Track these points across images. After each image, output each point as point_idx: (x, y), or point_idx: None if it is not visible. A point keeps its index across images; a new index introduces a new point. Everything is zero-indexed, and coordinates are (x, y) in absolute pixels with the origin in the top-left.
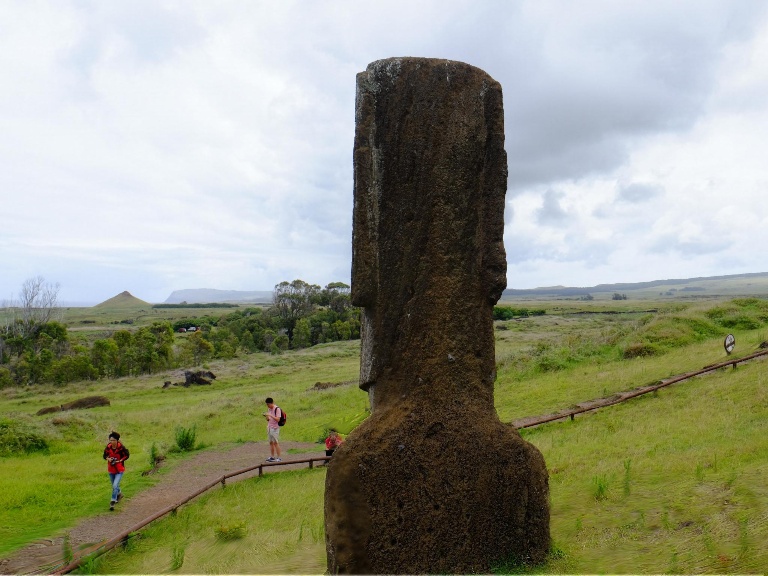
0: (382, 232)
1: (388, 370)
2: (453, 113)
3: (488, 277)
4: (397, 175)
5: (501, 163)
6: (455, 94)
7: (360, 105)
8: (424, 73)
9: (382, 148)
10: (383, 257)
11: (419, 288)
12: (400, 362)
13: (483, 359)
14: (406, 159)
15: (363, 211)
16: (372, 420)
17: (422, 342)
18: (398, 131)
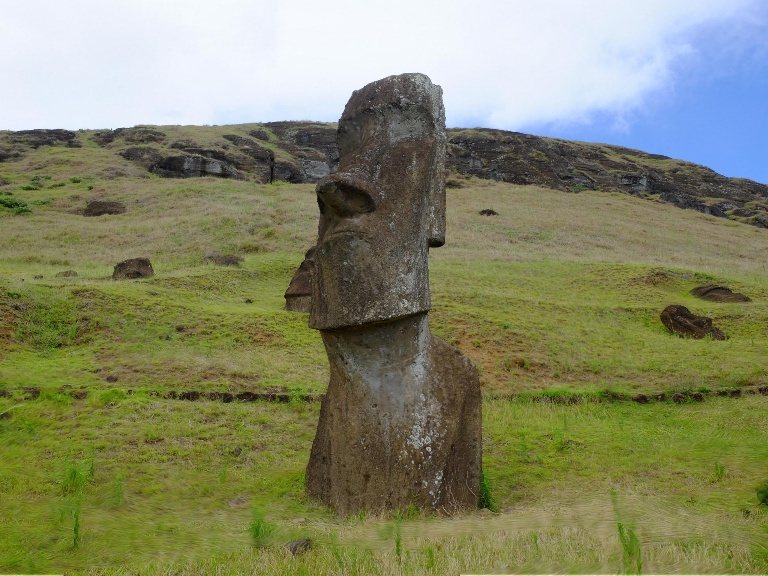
0: None
1: None
2: None
3: None
4: None
5: None
6: None
7: None
8: None
9: None
10: None
11: None
12: None
13: None
14: None
15: None
16: None
17: None
18: None
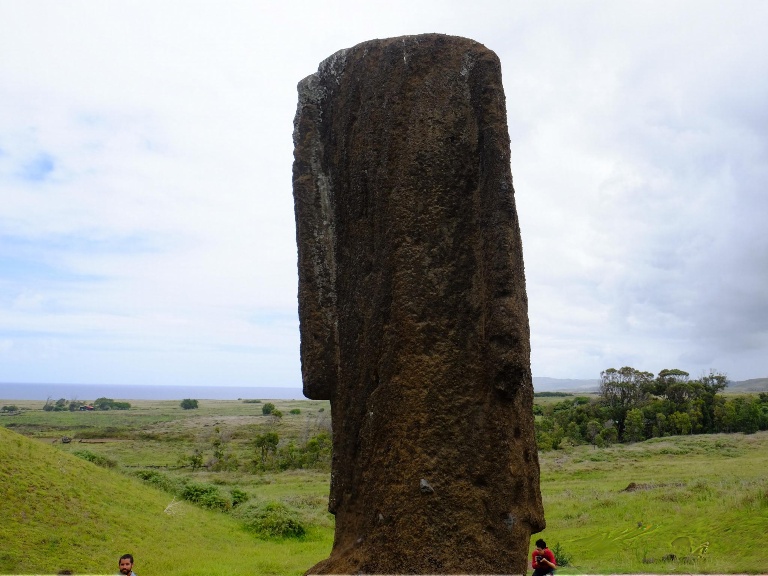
0: (340, 292)
1: (348, 496)
2: (415, 107)
3: (491, 354)
4: (349, 209)
5: (498, 171)
6: (418, 79)
7: (299, 121)
8: (373, 59)
9: (331, 174)
10: (342, 328)
11: (383, 373)
12: (360, 486)
13: (490, 490)
14: (356, 184)
15: (308, 264)
16: (309, 573)
17: (386, 457)
18: (345, 147)
